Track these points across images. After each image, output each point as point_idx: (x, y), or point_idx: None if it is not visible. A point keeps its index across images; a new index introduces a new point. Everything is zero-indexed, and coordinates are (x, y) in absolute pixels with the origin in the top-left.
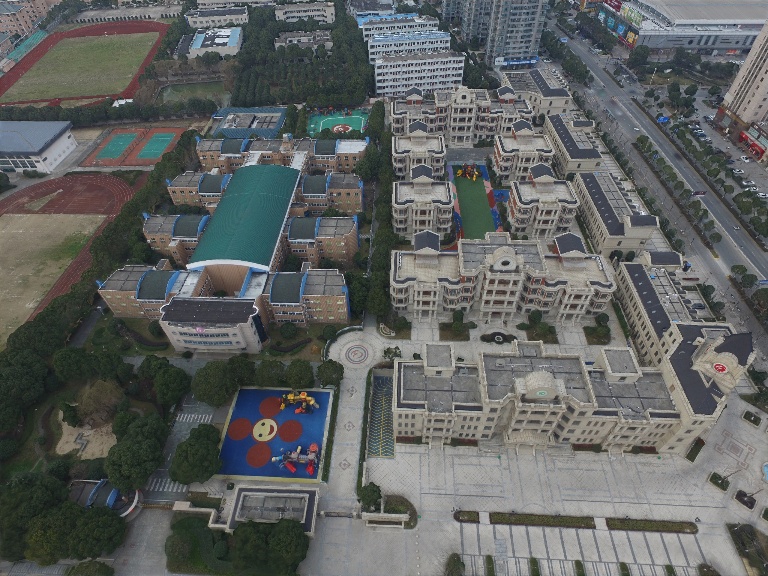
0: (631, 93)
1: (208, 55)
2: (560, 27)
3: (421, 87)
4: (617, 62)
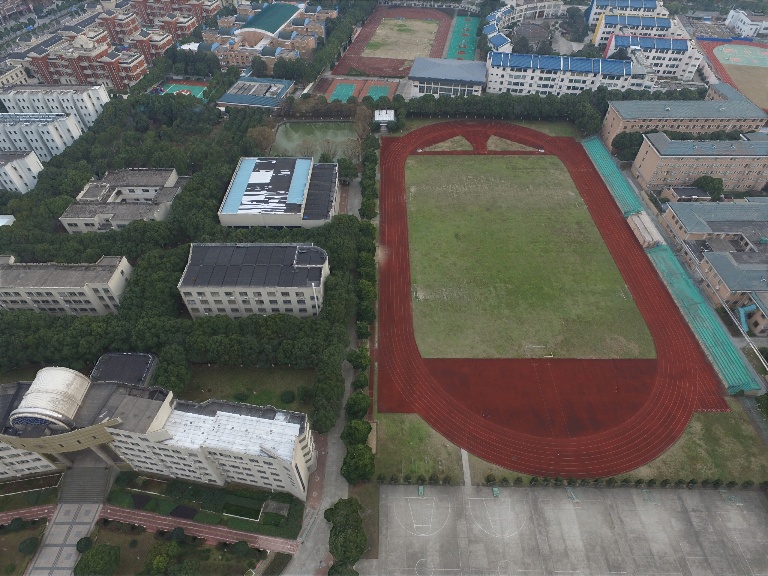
0: None
1: None
2: None
3: None
4: None
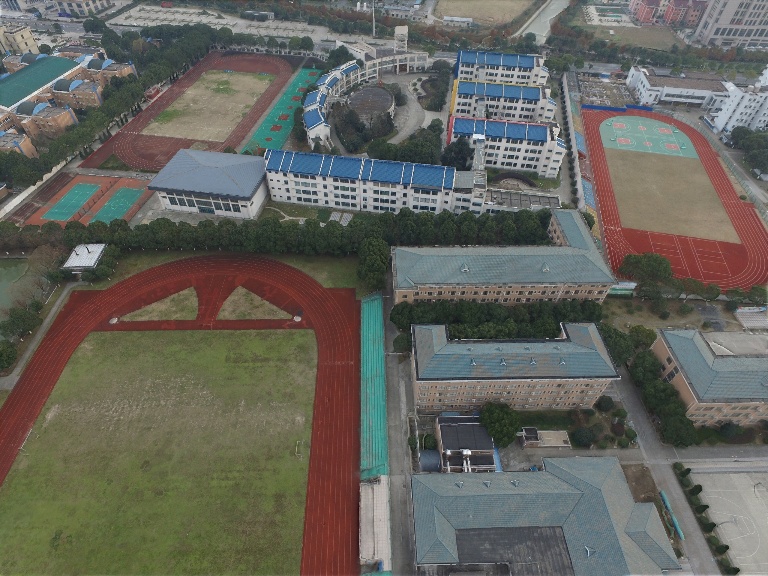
0: None
1: None
2: None
3: None
4: None
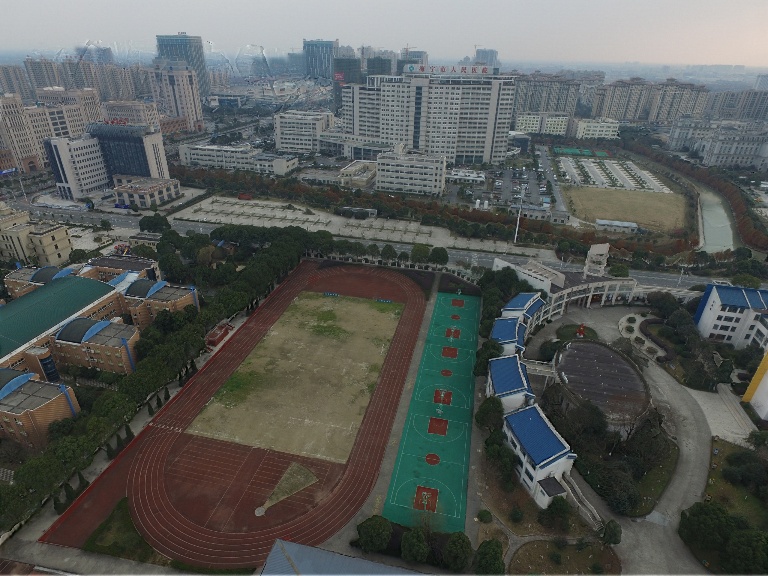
0: None
1: None
2: None
3: None
4: None
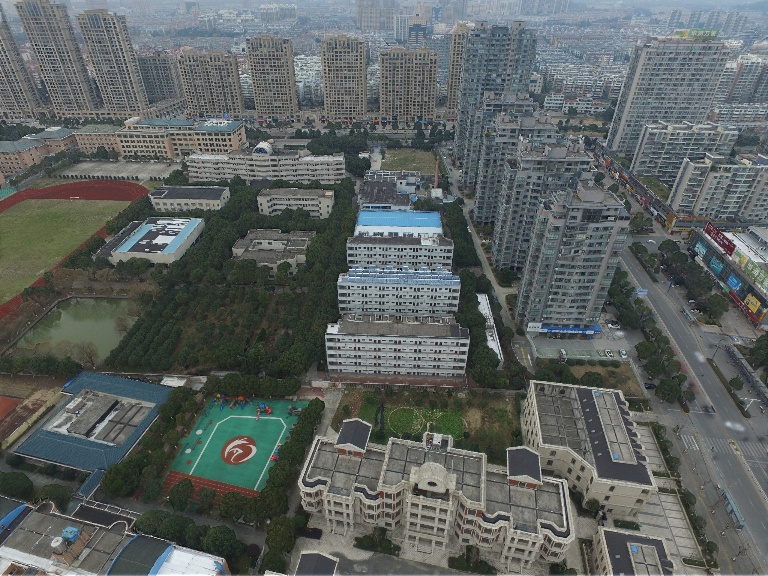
0: (766, 437)
1: (132, 263)
2: (636, 254)
3: (398, 369)
4: (732, 349)
